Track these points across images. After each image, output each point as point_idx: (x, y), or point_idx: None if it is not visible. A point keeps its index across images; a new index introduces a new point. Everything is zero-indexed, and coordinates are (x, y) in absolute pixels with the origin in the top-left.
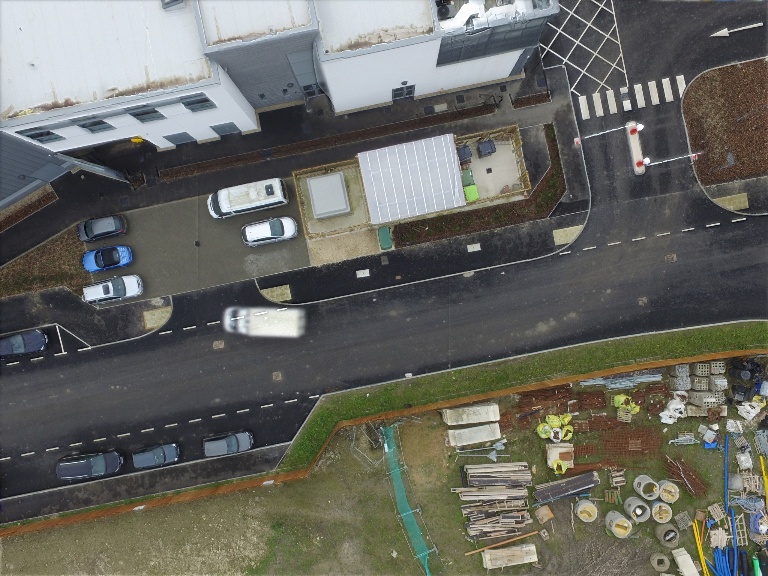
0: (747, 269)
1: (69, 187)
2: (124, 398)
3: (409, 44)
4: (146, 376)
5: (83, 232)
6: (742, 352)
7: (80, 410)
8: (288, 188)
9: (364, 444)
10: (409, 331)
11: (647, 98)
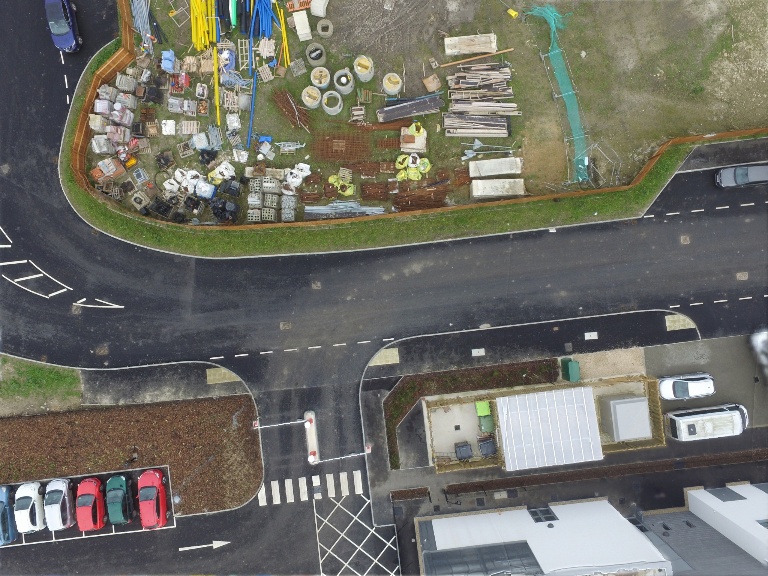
0: (213, 308)
1: None
2: None
3: (571, 569)
4: None
5: None
6: (230, 228)
7: None
8: None
9: (603, 165)
10: (549, 274)
11: (296, 486)
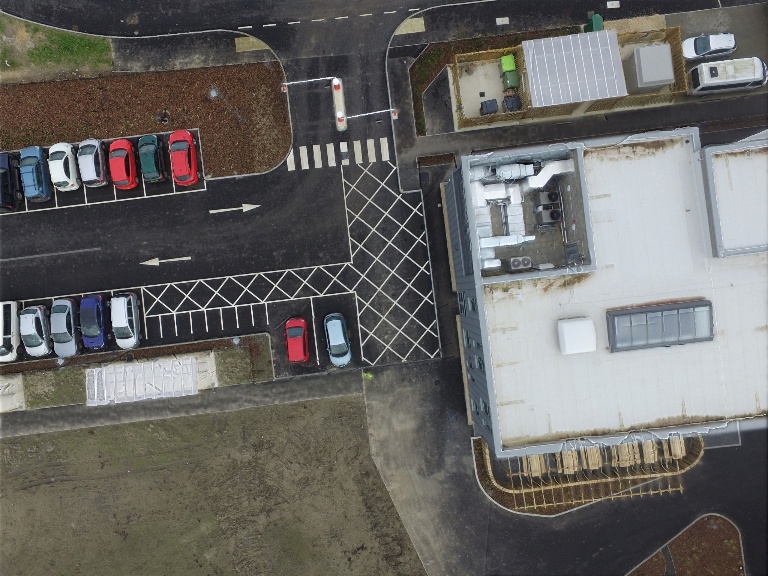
0: None
1: None
2: None
3: None
4: None
5: None
6: None
7: None
8: None
9: None
10: None
11: (324, 152)
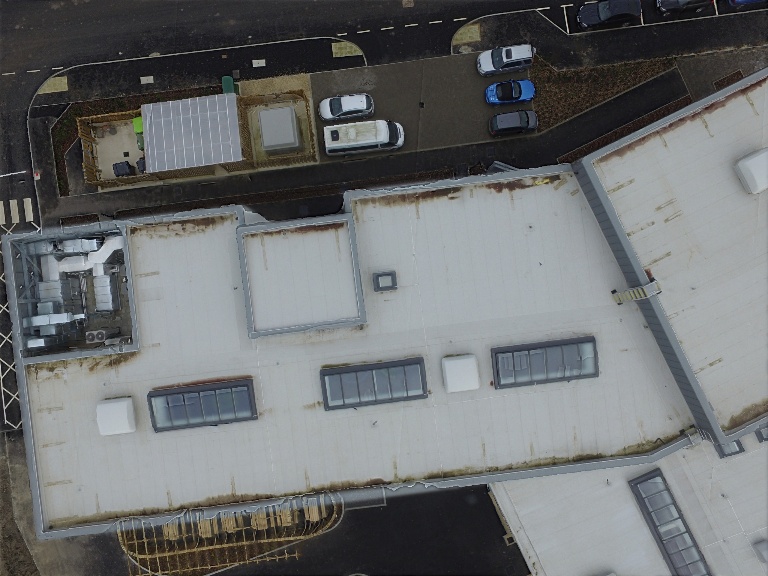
0: None
1: None
2: None
3: None
4: None
5: (532, 120)
6: None
7: None
8: None
9: None
10: (218, 3)
11: None
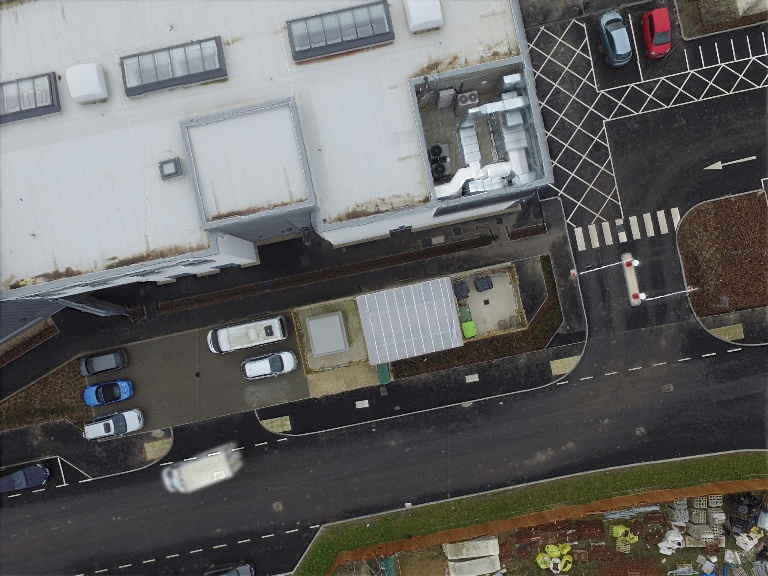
0: (743, 399)
1: (70, 320)
2: (125, 529)
3: (406, 209)
4: (147, 507)
5: (84, 367)
6: (739, 486)
7: (81, 541)
8: (287, 321)
9: (364, 574)
10: (408, 461)
11: (642, 230)
